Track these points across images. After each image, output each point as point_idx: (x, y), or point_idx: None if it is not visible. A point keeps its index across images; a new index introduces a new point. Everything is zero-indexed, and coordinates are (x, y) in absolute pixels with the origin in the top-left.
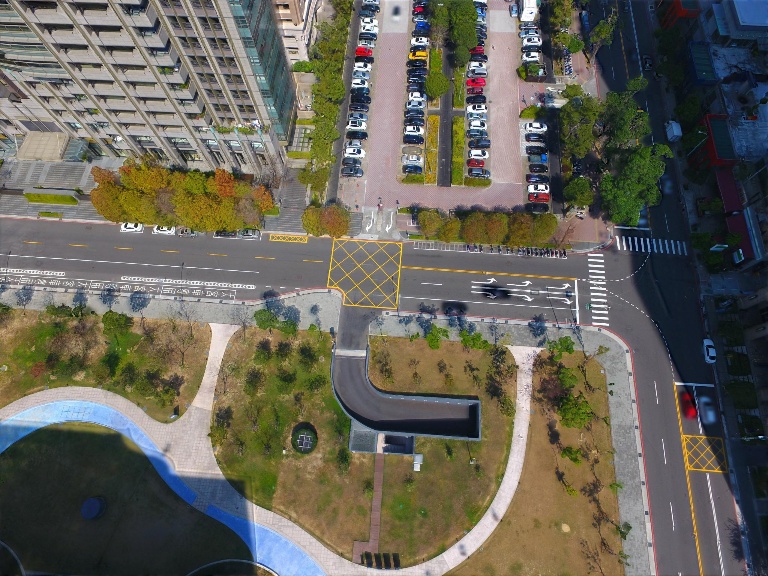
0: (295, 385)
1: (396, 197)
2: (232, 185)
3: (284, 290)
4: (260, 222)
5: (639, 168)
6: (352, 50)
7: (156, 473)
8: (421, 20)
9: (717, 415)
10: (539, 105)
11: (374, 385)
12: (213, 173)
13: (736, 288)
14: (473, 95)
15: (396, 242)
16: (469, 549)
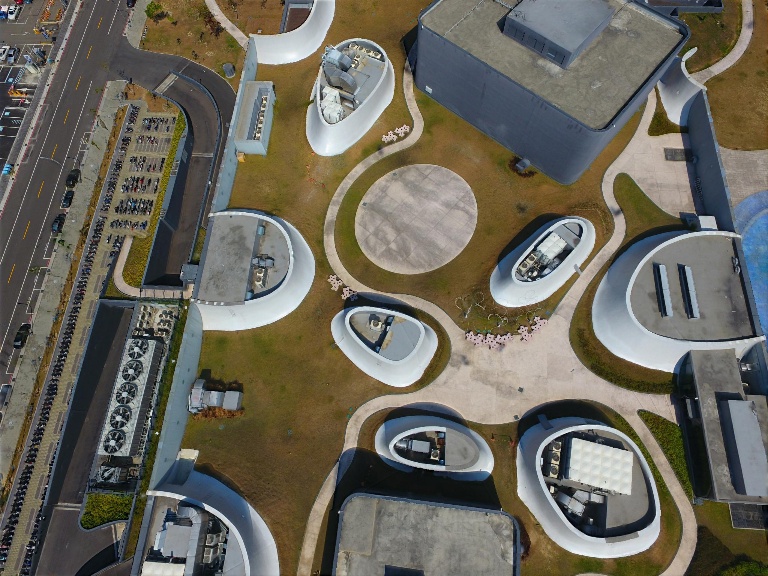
0: None
1: None
2: None
3: None
4: None
5: None
6: None
7: None
8: None
9: None
10: None
11: None
12: None
13: None
14: None
15: None
16: (726, 65)
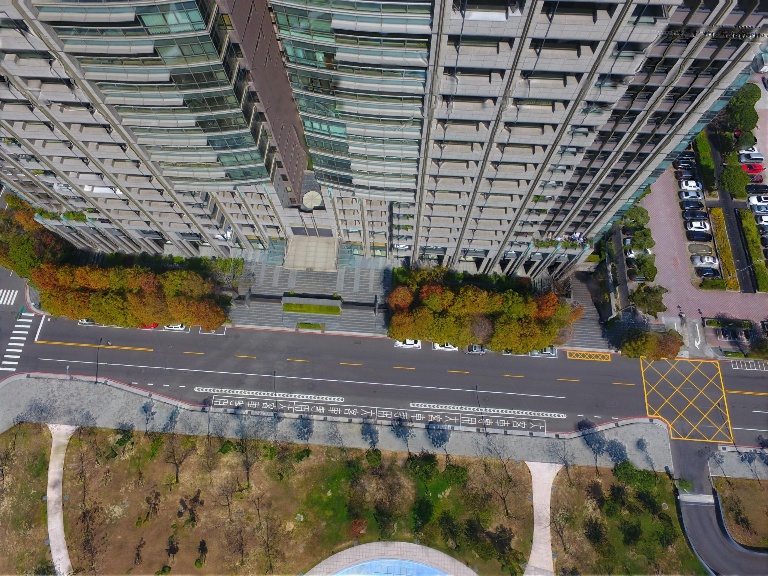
0: None
1: (697, 305)
2: (555, 307)
3: (600, 420)
4: None
5: None
6: None
7: None
8: None
9: None
10: None
11: None
12: (486, 276)
13: None
14: (751, 183)
15: (711, 360)
16: None
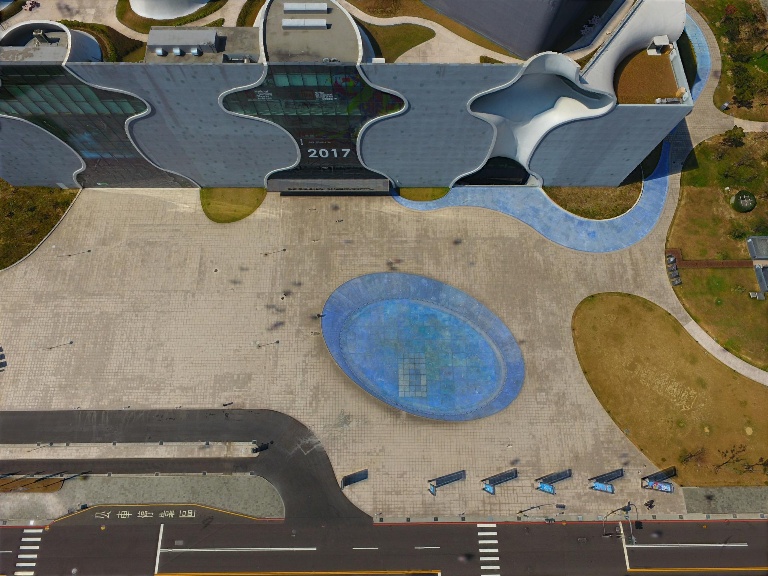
0: None
1: None
2: None
3: None
4: None
5: None
6: None
7: None
8: None
9: None
10: None
11: None
12: None
13: None
14: None
15: None
16: (703, 342)
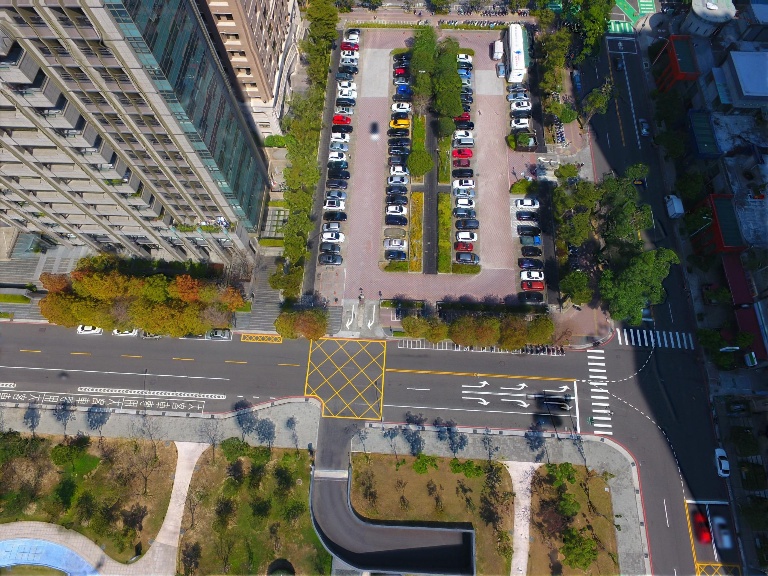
0: (270, 514)
1: (378, 287)
2: (196, 290)
3: (257, 400)
4: (230, 323)
5: (642, 272)
6: (329, 118)
7: None
8: (402, 83)
9: (733, 538)
10: (530, 179)
11: (357, 512)
12: (179, 263)
13: (748, 387)
14: (459, 168)
15: (379, 340)
16: None
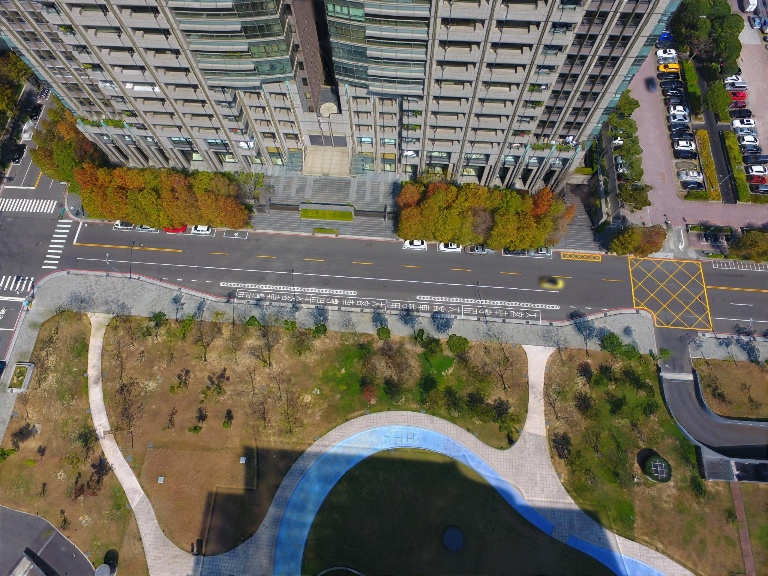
0: None
1: (682, 214)
2: (549, 203)
3: (590, 310)
4: None
5: None
6: None
7: (505, 502)
8: None
9: None
10: None
11: None
12: None
13: None
14: (735, 109)
15: (693, 261)
16: None
